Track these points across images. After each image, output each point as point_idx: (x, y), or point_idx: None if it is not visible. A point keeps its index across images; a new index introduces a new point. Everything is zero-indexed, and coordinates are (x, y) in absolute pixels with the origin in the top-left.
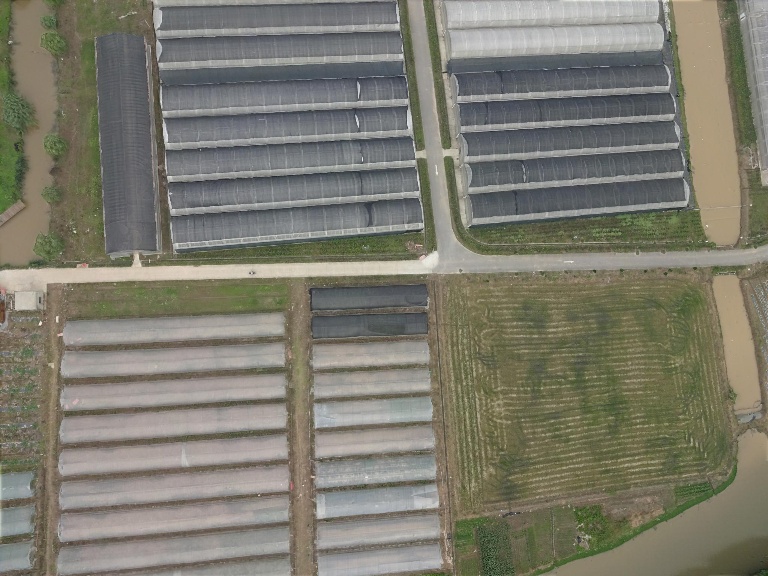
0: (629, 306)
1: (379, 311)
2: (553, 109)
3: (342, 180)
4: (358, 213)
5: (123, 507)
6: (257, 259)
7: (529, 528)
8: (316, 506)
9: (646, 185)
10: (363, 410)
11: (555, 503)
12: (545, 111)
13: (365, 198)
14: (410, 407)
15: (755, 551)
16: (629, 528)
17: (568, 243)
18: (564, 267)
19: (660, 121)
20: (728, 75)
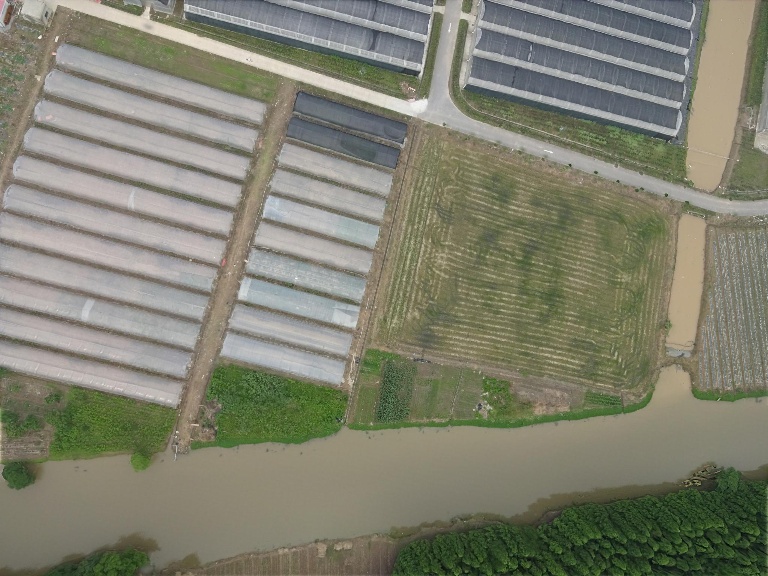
0: (594, 211)
1: (356, 134)
2: (575, 5)
3: (358, 1)
4: (364, 34)
5: (61, 226)
6: (258, 50)
7: (435, 379)
8: (240, 286)
9: (642, 103)
10: (312, 214)
11: (467, 365)
12: (567, 6)
13: (375, 25)
14: (357, 227)
15: (648, 486)
16: (531, 413)
17: (553, 135)
18: (543, 154)
19: (673, 52)
20: (751, 38)
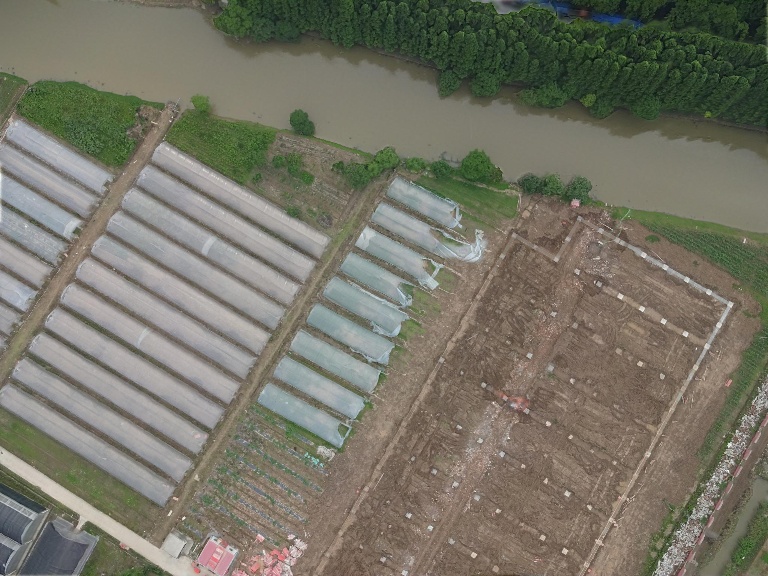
0: None
1: None
2: None
3: None
4: None
5: (215, 330)
6: None
7: None
8: None
9: None
10: None
11: None
12: None
13: None
14: None
15: None
16: None
17: None
18: None
19: None
20: None
